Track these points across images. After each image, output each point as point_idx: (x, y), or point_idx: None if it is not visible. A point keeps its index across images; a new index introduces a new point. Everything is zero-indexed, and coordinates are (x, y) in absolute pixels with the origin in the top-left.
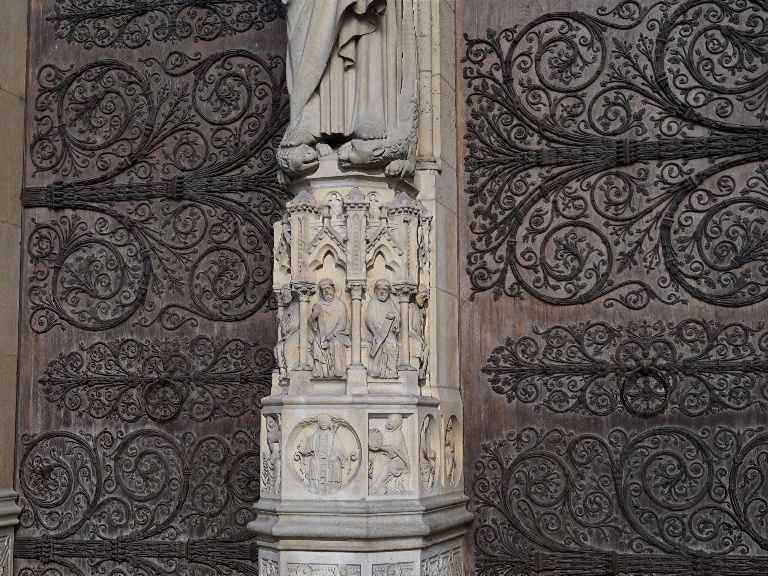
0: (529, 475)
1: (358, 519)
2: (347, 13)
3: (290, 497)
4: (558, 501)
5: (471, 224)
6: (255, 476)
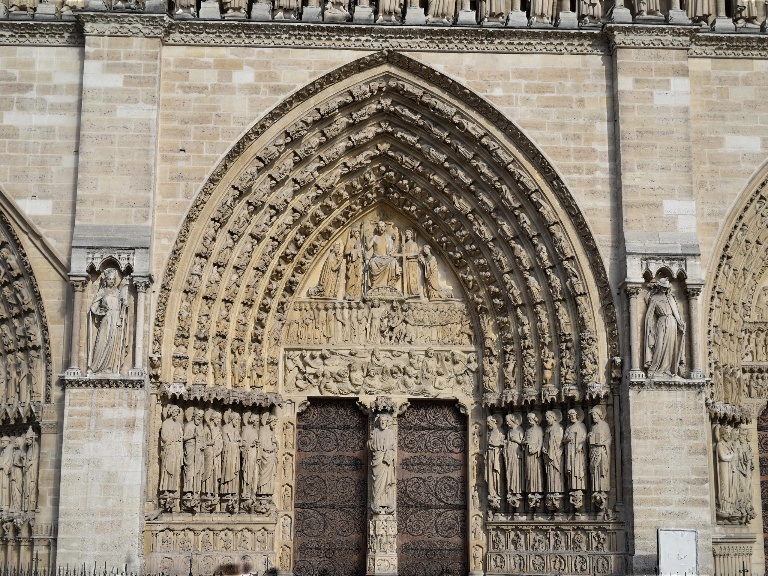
0: (409, 570)
1: None
2: (388, 484)
3: (377, 573)
4: (414, 575)
5: (398, 519)
6: (351, 570)
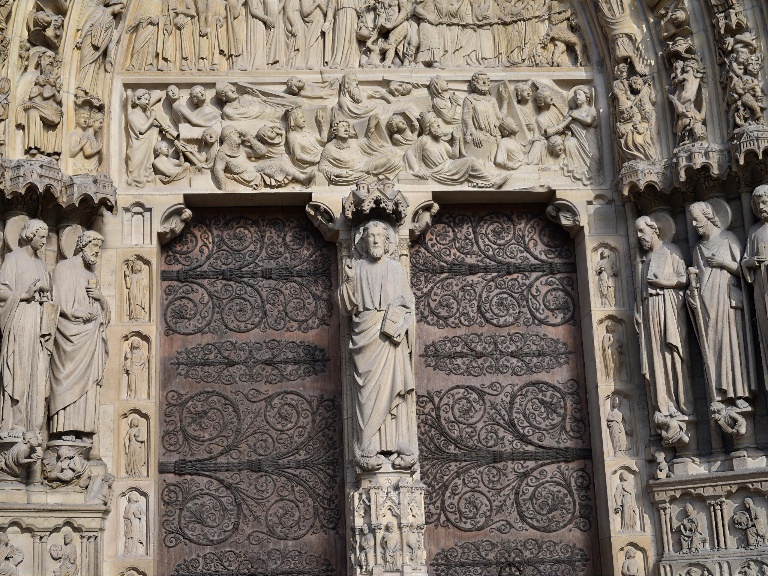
0: None
1: None
2: None
3: None
4: None
5: None
6: None
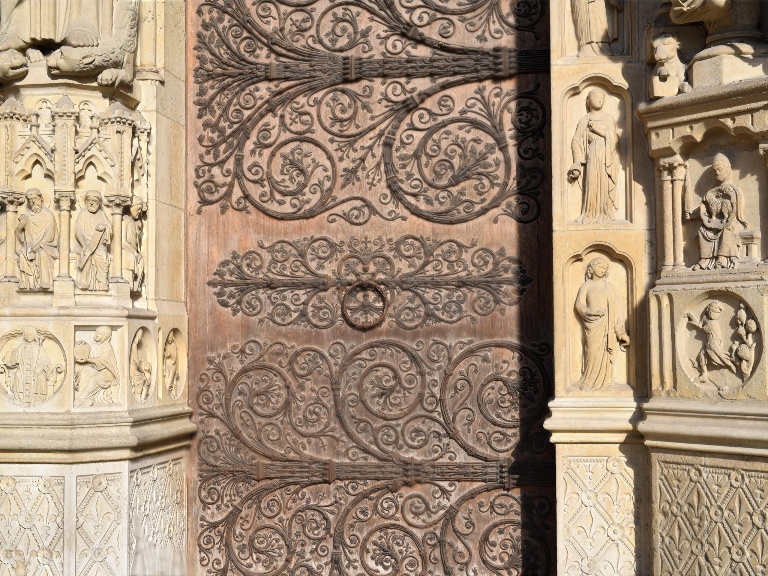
0: (252, 387)
1: (62, 431)
2: None
3: None
4: (279, 412)
5: (199, 137)
6: None
